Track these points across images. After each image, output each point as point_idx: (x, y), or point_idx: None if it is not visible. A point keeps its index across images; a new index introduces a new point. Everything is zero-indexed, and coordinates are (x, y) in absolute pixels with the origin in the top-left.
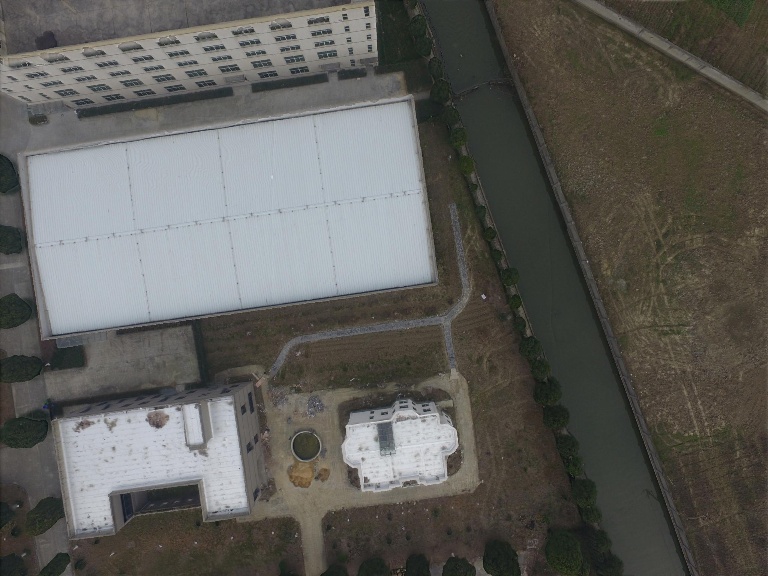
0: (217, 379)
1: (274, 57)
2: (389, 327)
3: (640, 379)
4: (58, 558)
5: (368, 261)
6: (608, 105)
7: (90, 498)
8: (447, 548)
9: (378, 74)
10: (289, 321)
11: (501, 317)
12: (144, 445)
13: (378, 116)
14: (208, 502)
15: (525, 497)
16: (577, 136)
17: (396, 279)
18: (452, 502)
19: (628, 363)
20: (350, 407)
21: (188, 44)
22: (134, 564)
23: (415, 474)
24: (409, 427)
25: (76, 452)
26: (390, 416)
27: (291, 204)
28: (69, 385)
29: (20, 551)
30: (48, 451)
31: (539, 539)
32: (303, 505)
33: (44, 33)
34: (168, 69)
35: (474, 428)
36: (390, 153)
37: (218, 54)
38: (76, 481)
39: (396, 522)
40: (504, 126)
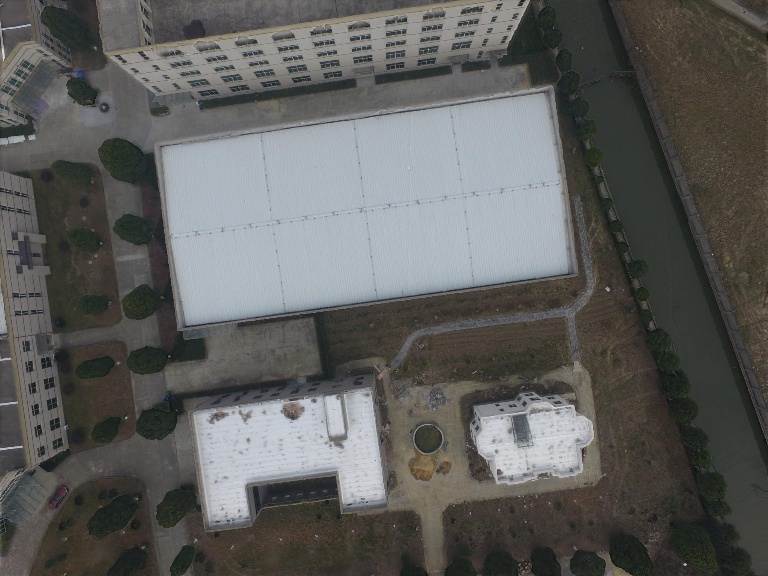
0: (338, 371)
1: (411, 48)
2: (513, 319)
3: (762, 372)
4: (186, 551)
5: (505, 252)
6: (731, 98)
7: (224, 490)
8: (569, 541)
9: (502, 66)
10: (412, 313)
11: (625, 310)
12: (279, 437)
13: (515, 107)
14: (343, 494)
15: (648, 490)
16: (700, 129)
17: (533, 270)
18: (574, 495)
19: (750, 356)
20: (473, 400)
21: (338, 33)
22: (253, 557)
23: (549, 466)
24: (543, 419)
25: (210, 444)
26: (524, 408)
27: (429, 195)
28: (189, 377)
29: (138, 544)
30: (167, 444)
31: (661, 533)
32: (424, 498)
33: (192, 22)
34: (306, 59)
35: (597, 421)
36: (528, 144)
37: (360, 44)
38: (210, 473)
39: (518, 515)
40: (624, 119)
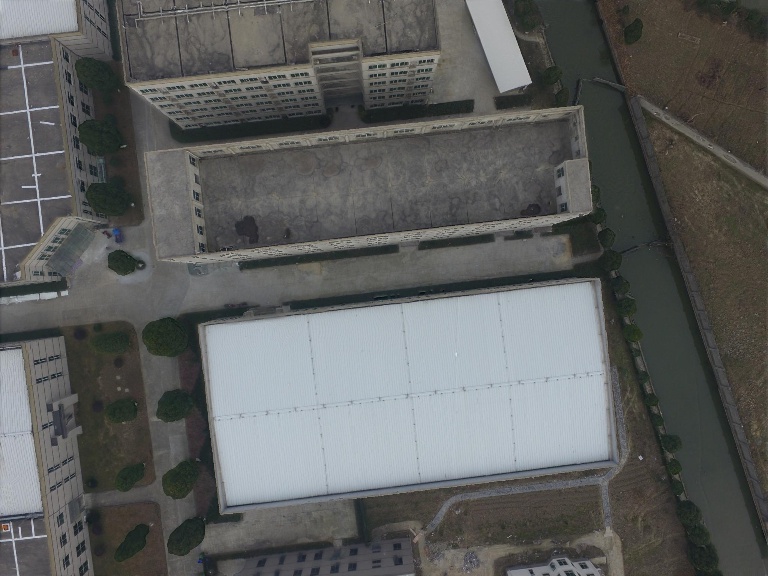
0: (374, 534)
1: (460, 233)
2: (548, 487)
3: None
4: None
5: (548, 439)
6: (764, 272)
7: None
8: None
9: (544, 236)
10: None
11: (656, 478)
12: None
13: (562, 295)
14: None
15: None
16: (733, 301)
17: (574, 456)
18: None
19: None
20: (506, 564)
21: (393, 236)
22: None
23: None
24: None
25: None
26: None
27: (475, 382)
28: (223, 539)
29: None
30: None
31: None
32: None
33: (244, 218)
34: (355, 244)
35: None
36: (573, 333)
37: None
38: None
39: None
40: (659, 285)
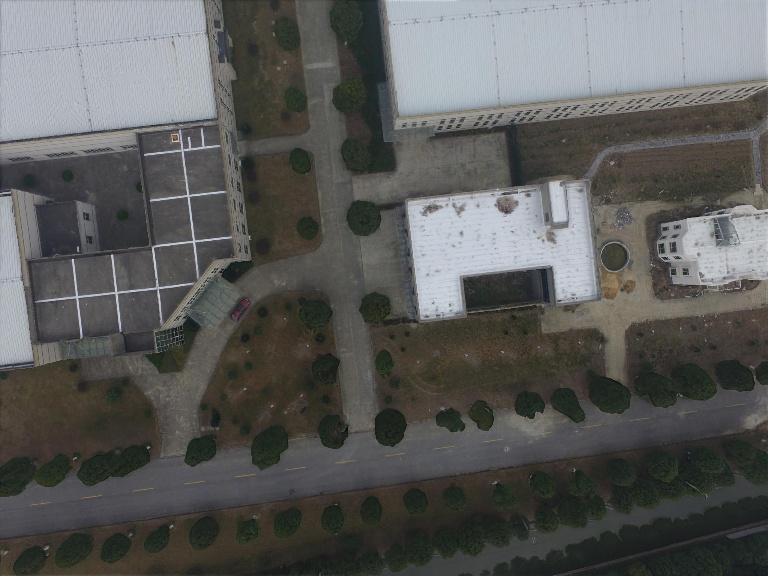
0: None
1: None
2: (700, 140)
3: None
4: (385, 353)
5: (717, 55)
6: None
7: (435, 283)
8: (745, 361)
9: None
10: (603, 131)
11: None
12: (492, 230)
13: None
14: None
15: None
16: None
17: (742, 74)
18: (752, 315)
19: None
20: (659, 219)
21: None
22: (438, 374)
23: (748, 270)
24: (744, 224)
25: (423, 236)
26: (726, 212)
27: None
28: (377, 190)
29: None
30: (353, 257)
31: None
32: (608, 317)
33: None
34: None
35: None
36: None
37: None
38: (422, 266)
39: (698, 334)
40: None
